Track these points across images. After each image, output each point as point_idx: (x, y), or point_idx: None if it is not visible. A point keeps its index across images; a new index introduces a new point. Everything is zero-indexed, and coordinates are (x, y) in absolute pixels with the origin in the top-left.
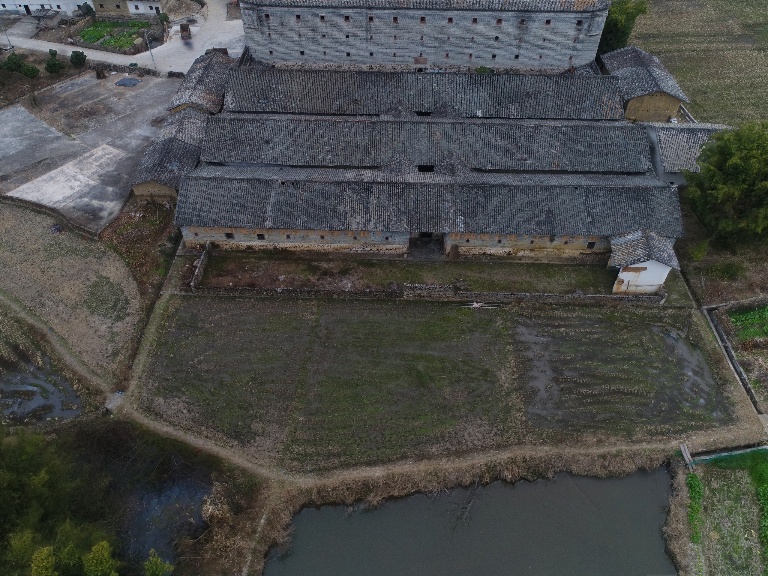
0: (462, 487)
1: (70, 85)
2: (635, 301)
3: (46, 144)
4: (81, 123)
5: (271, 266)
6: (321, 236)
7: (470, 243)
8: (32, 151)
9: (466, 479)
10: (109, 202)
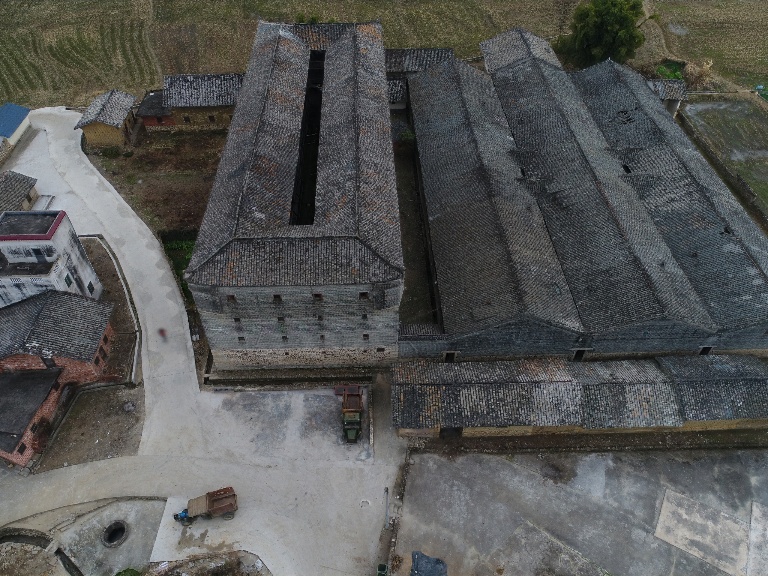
0: None
1: None
2: None
3: None
4: None
5: None
6: None
7: None
8: None
9: None
10: None
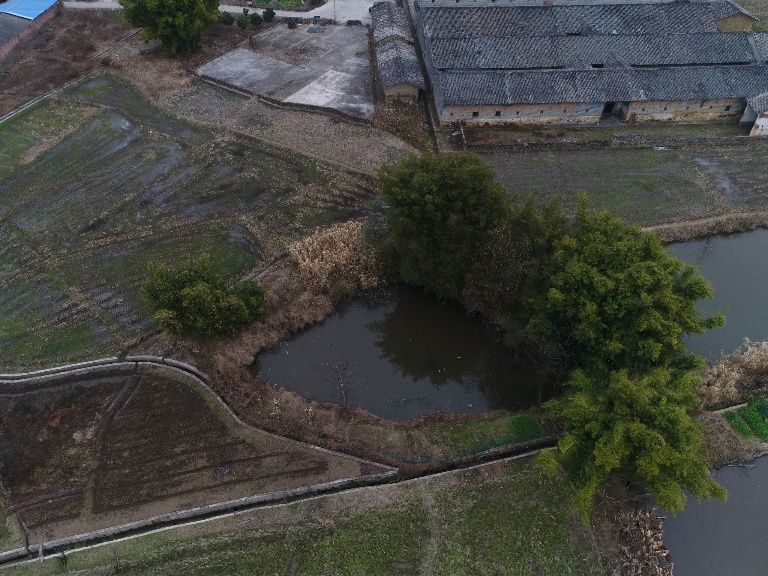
0: (701, 237)
1: (271, 34)
2: (767, 140)
3: (285, 72)
4: (301, 58)
5: (507, 134)
6: (541, 111)
7: (644, 111)
8: (278, 76)
9: (704, 230)
10: (362, 104)
